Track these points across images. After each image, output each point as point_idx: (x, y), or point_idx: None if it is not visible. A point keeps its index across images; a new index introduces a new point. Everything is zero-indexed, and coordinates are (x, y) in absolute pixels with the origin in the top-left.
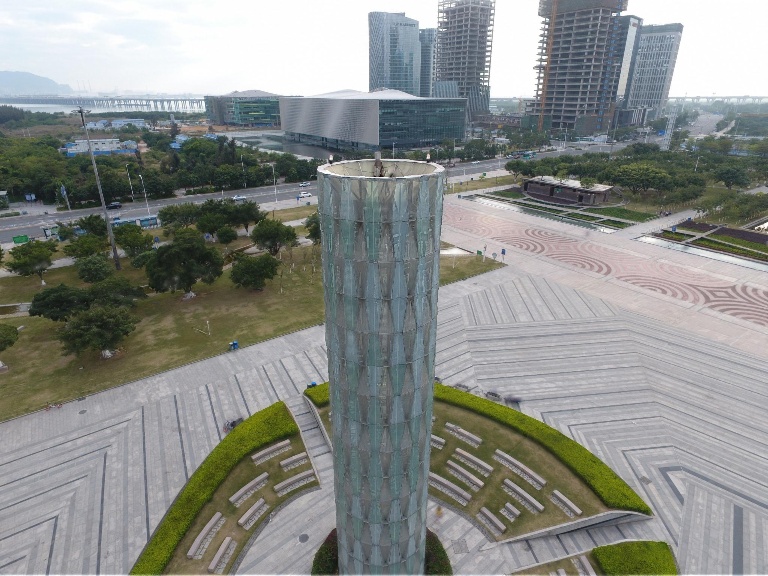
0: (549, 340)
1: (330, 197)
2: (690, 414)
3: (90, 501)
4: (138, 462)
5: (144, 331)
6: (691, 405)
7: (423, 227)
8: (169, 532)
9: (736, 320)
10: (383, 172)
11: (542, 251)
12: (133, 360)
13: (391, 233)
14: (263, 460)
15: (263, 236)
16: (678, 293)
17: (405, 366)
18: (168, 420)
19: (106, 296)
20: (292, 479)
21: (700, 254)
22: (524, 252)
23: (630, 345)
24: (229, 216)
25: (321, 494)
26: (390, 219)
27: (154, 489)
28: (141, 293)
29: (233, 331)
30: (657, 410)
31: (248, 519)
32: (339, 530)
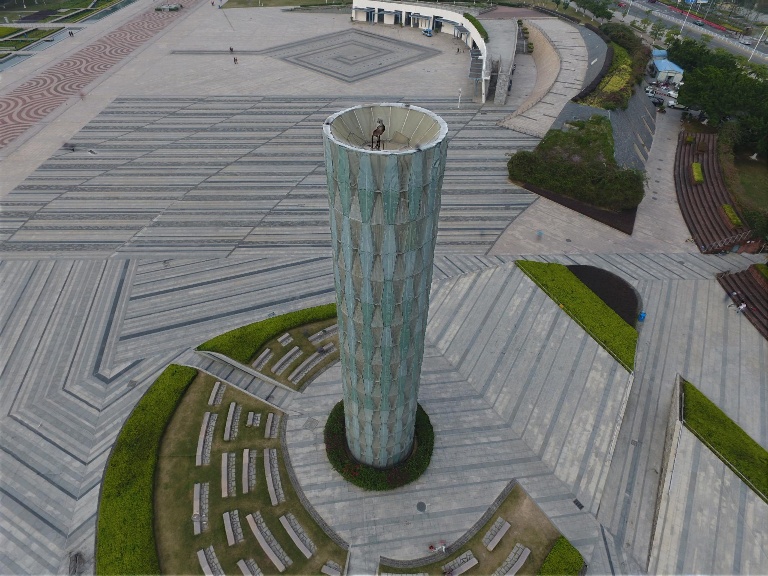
0: None
1: None
2: None
3: None
4: None
5: None
6: None
7: None
8: None
9: None
10: None
11: None
12: None
13: None
14: None
15: None
16: None
17: None
18: None
19: None
20: None
21: None
22: None
23: None
24: None
25: (384, 549)
26: None
27: None
28: None
29: None
30: None
31: None
32: None
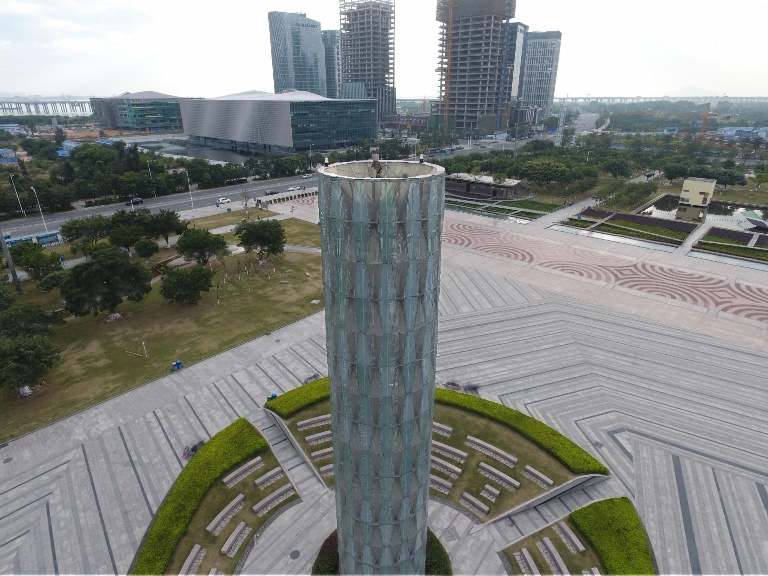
0: (492, 327)
1: (340, 200)
2: (623, 381)
3: (39, 559)
4: (90, 506)
5: (67, 361)
6: (622, 372)
7: (431, 225)
8: (145, 575)
9: (643, 294)
10: (381, 173)
11: (470, 244)
12: (60, 394)
13: (405, 233)
14: (236, 482)
15: (190, 246)
16: (593, 274)
17: (416, 364)
18: (116, 455)
19: (15, 326)
20: (271, 496)
21: (604, 238)
22: (453, 246)
23: (562, 325)
24: (146, 227)
25: (304, 507)
26: (404, 219)
27: (115, 532)
28: (57, 319)
29: (173, 350)
30: (596, 380)
31: (231, 546)
32: (343, 538)
